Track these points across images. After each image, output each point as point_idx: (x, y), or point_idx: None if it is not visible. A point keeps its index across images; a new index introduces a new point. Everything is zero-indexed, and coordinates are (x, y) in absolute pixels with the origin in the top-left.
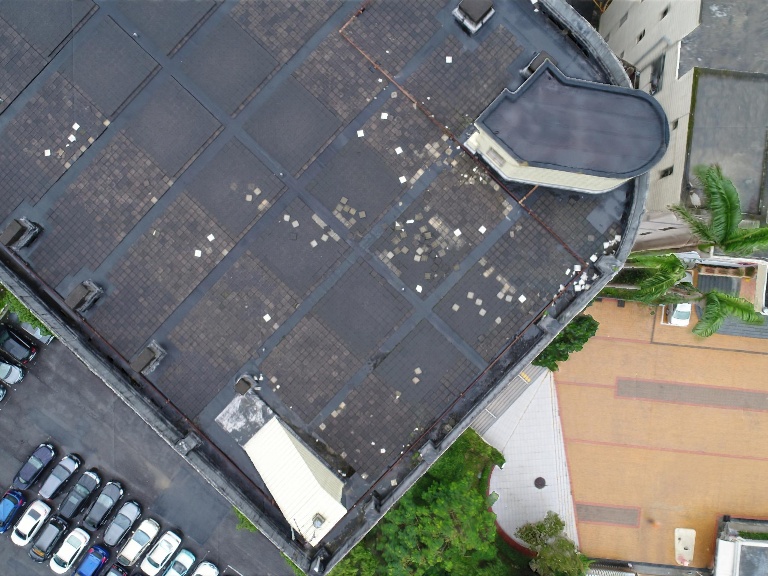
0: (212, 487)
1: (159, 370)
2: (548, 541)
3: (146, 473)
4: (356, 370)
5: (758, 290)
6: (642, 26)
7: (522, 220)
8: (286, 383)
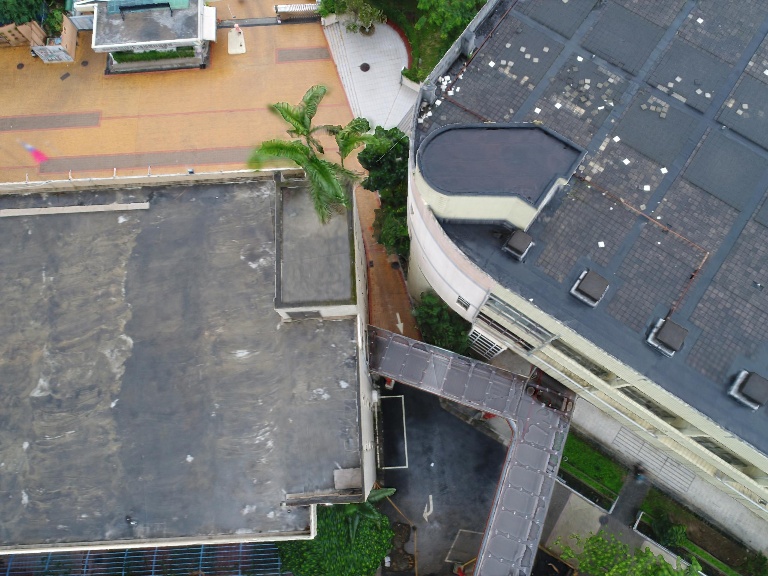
0: None
1: None
2: (364, 8)
3: None
4: None
5: None
6: None
7: None
8: None
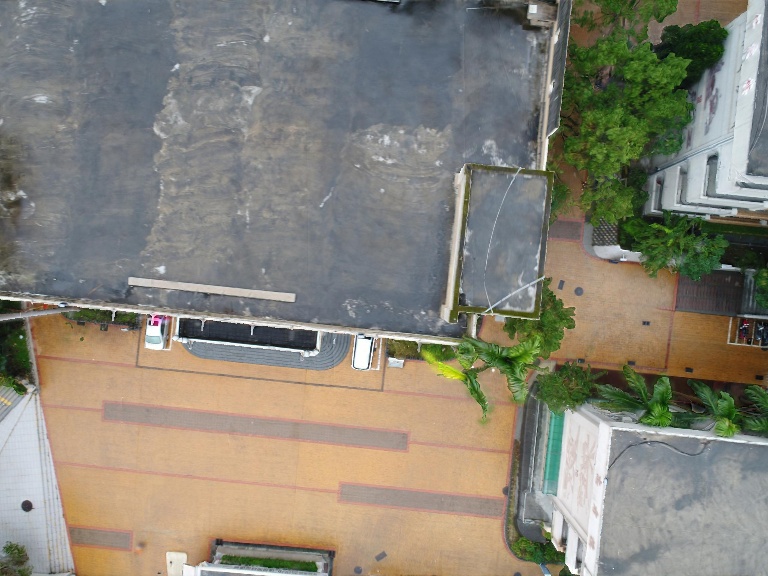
0: None
1: None
2: None
3: None
4: None
5: None
6: None
7: None
8: None
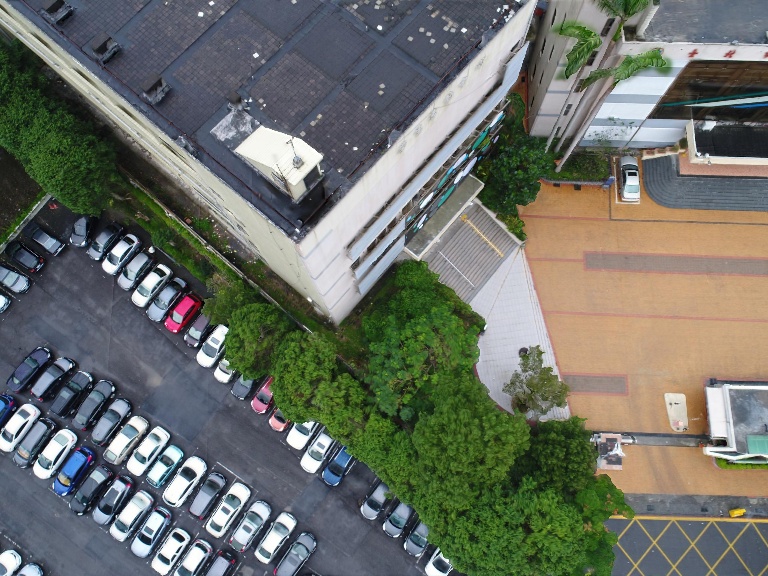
0: (203, 382)
1: (164, 101)
2: None
3: (139, 372)
4: (330, 89)
5: (690, 144)
6: None
7: None
8: (271, 102)
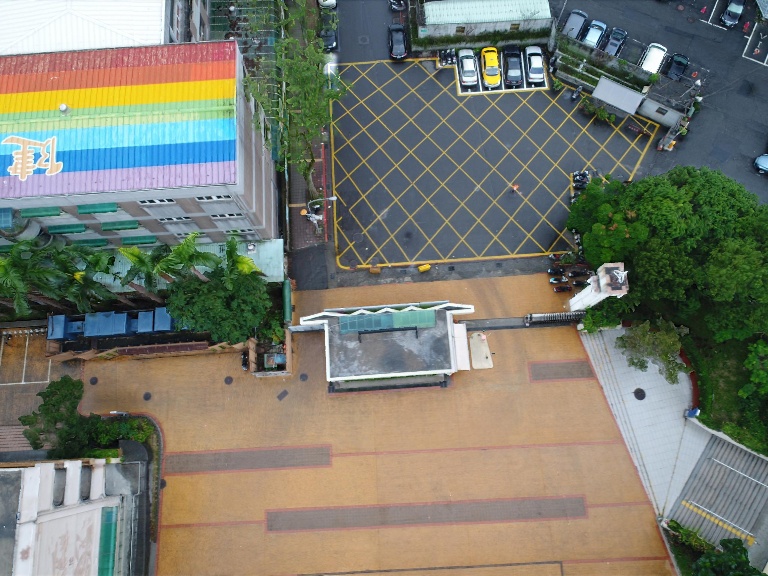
0: None
1: None
2: None
3: None
4: None
5: None
6: None
7: None
8: None
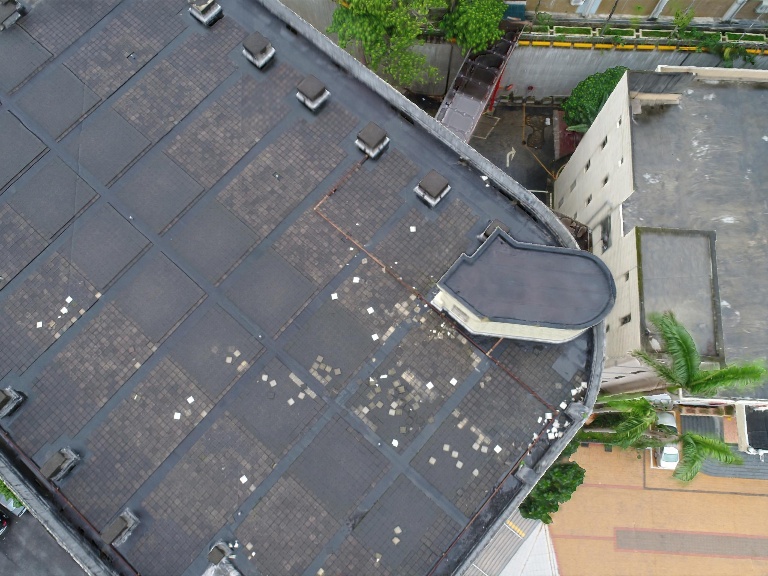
0: None
1: (131, 541)
2: None
3: None
4: (334, 532)
5: (740, 429)
6: (589, 192)
7: (491, 371)
8: (262, 549)
